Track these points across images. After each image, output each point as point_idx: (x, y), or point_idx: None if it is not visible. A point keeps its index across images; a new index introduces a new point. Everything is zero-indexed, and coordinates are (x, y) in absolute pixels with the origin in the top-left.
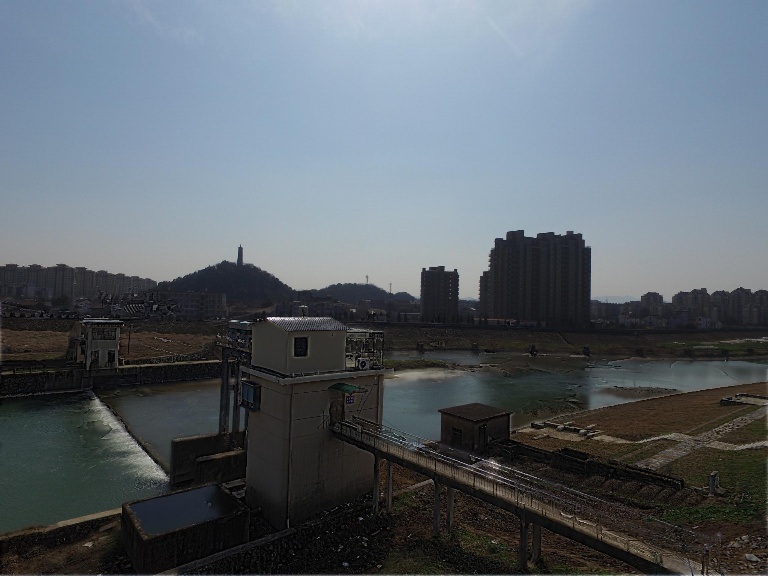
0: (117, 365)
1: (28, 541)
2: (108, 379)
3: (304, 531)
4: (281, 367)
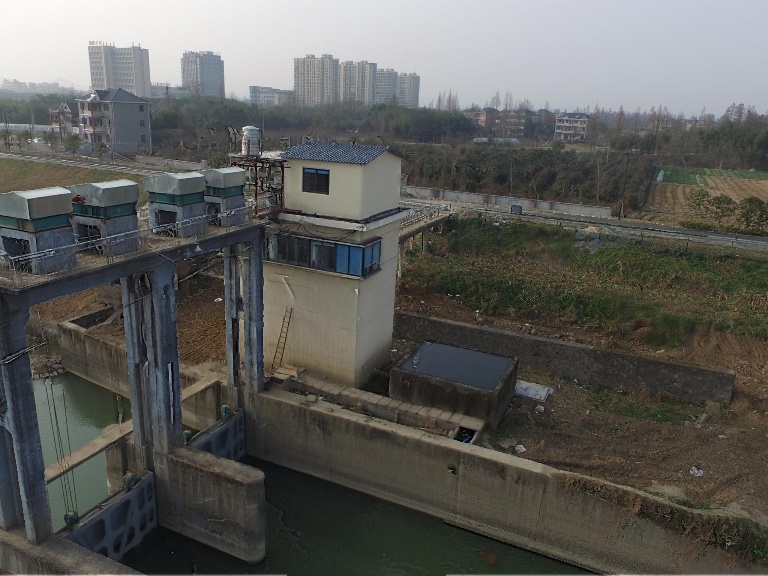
0: None
1: None
2: None
3: None
4: None
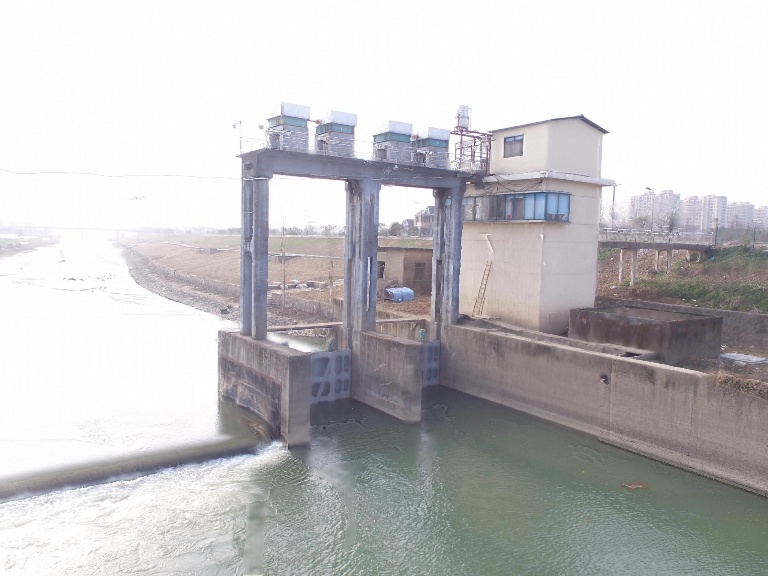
0: None
1: None
2: None
3: None
4: (594, 171)
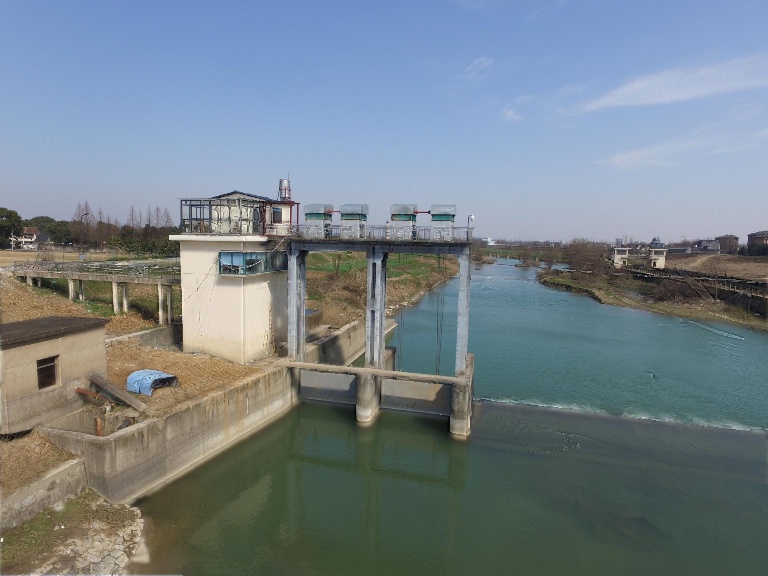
0: None
1: None
2: None
3: None
4: None
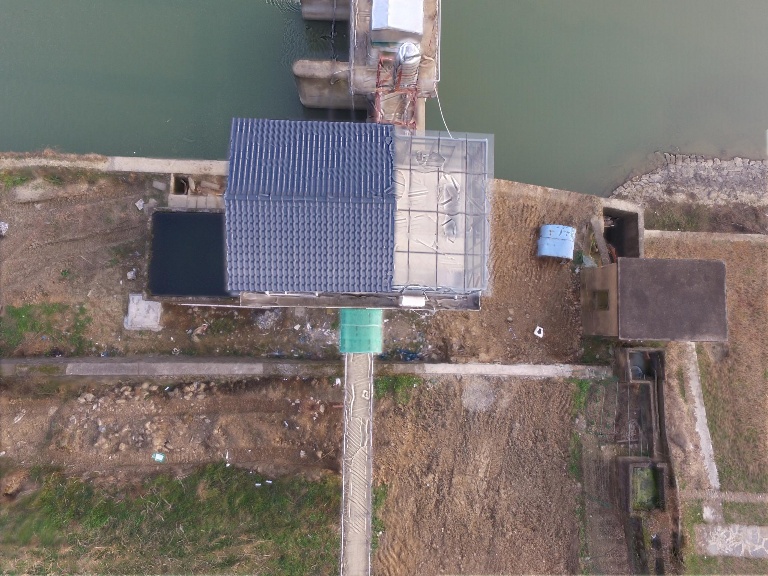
0: None
1: (92, 173)
2: None
3: (271, 374)
4: None
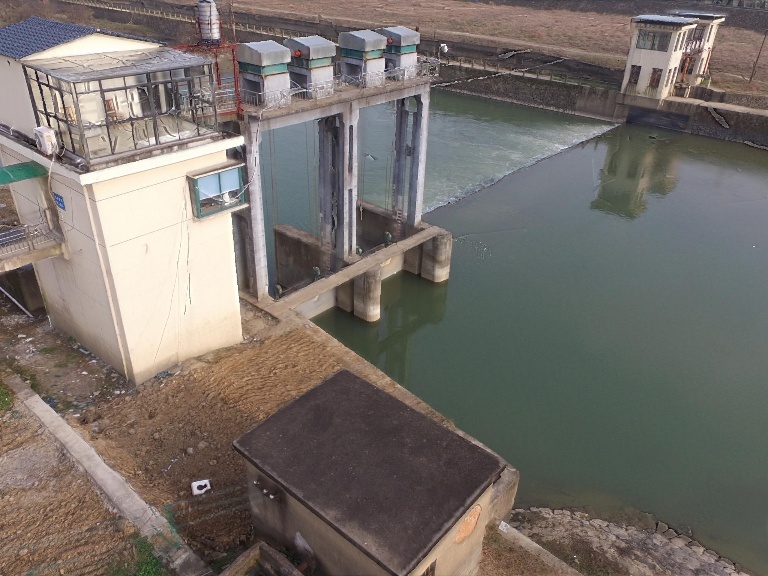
0: (661, 94)
1: None
2: (648, 113)
3: None
4: None
